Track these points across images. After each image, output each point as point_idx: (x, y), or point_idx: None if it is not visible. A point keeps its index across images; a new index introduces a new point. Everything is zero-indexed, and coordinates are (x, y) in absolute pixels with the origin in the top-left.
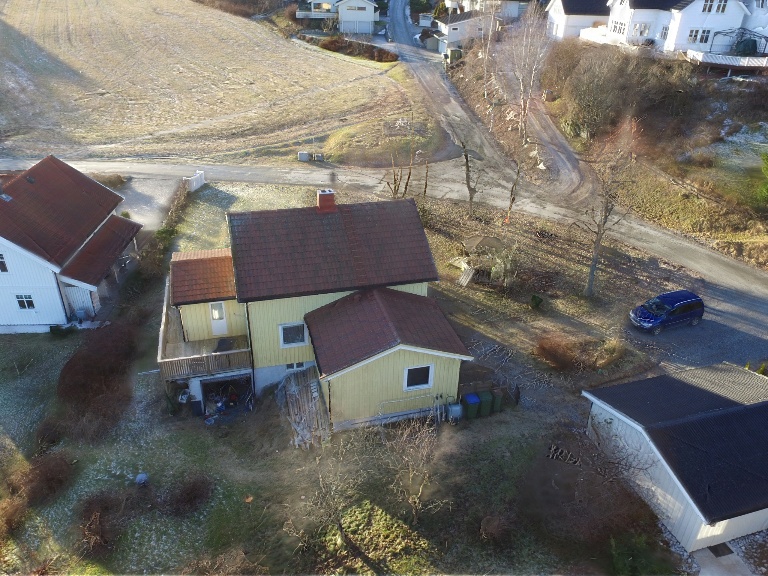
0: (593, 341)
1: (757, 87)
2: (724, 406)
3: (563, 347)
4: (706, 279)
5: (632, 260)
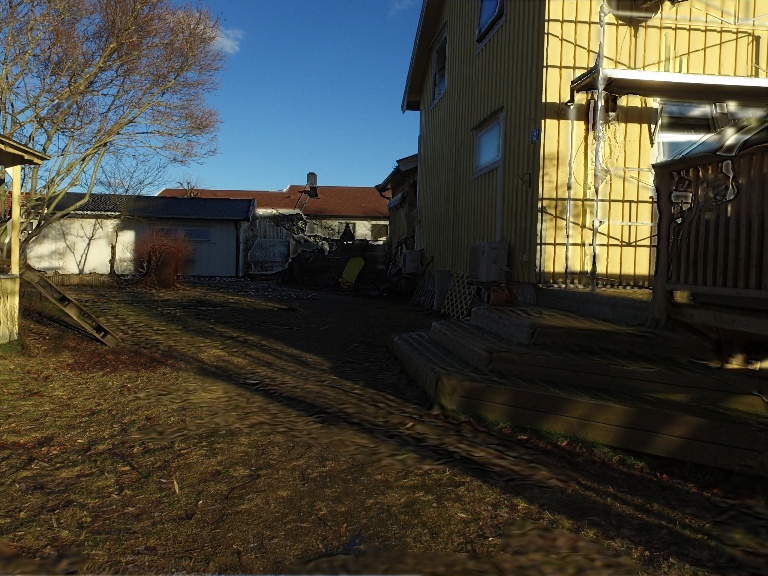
0: None
1: None
2: None
3: None
4: None
5: None
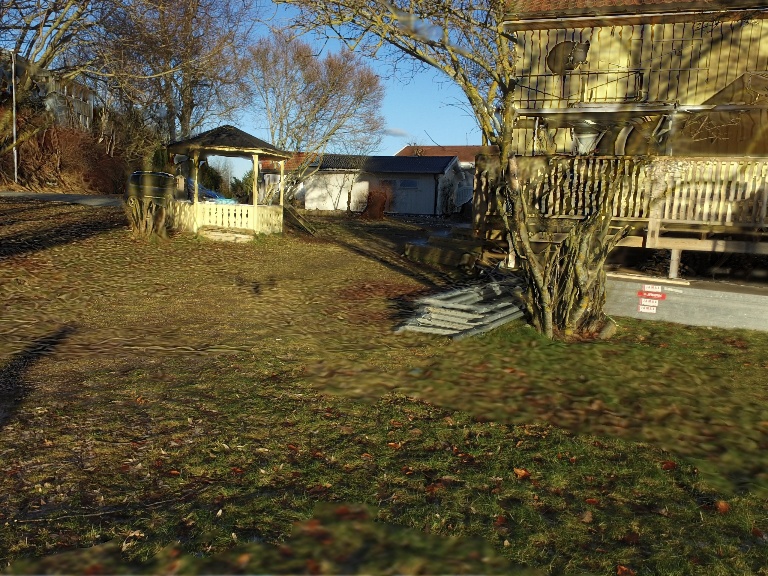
0: (305, 210)
1: None
2: (384, 156)
3: (378, 191)
4: None
5: None
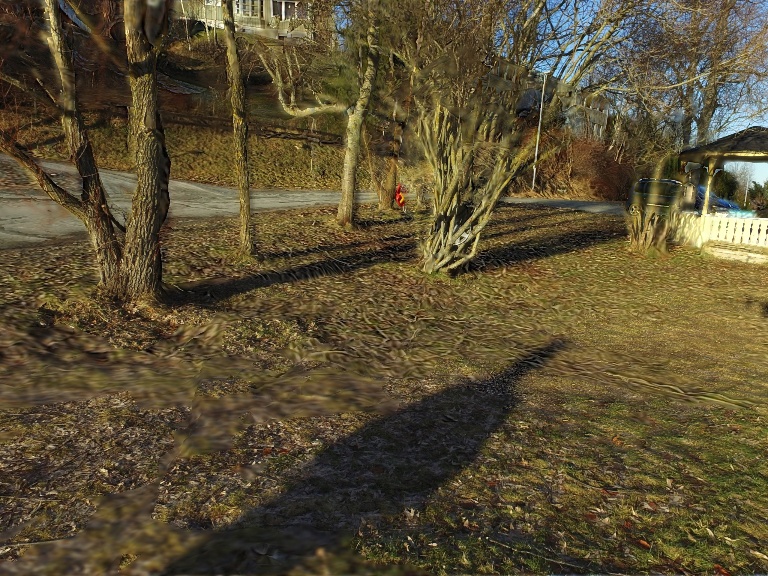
0: None
1: (87, 33)
2: None
3: None
4: (525, 202)
5: (505, 204)
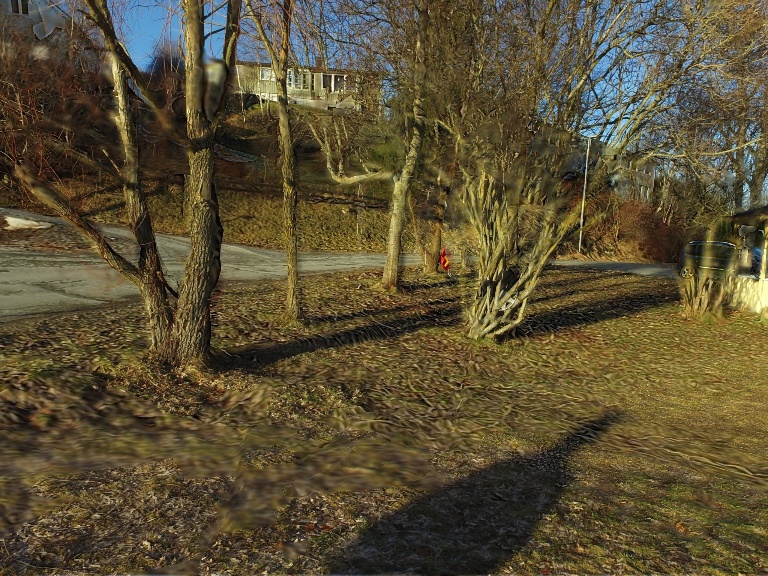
0: None
1: None
2: None
3: None
4: None
5: None
